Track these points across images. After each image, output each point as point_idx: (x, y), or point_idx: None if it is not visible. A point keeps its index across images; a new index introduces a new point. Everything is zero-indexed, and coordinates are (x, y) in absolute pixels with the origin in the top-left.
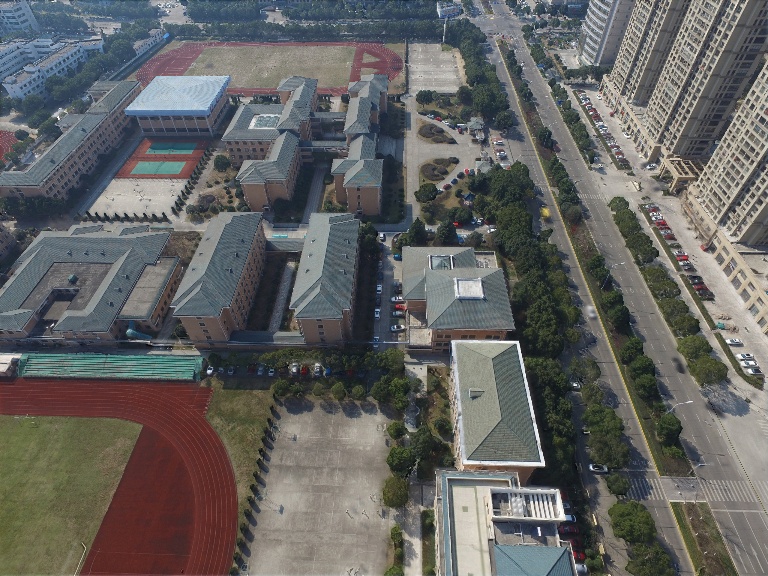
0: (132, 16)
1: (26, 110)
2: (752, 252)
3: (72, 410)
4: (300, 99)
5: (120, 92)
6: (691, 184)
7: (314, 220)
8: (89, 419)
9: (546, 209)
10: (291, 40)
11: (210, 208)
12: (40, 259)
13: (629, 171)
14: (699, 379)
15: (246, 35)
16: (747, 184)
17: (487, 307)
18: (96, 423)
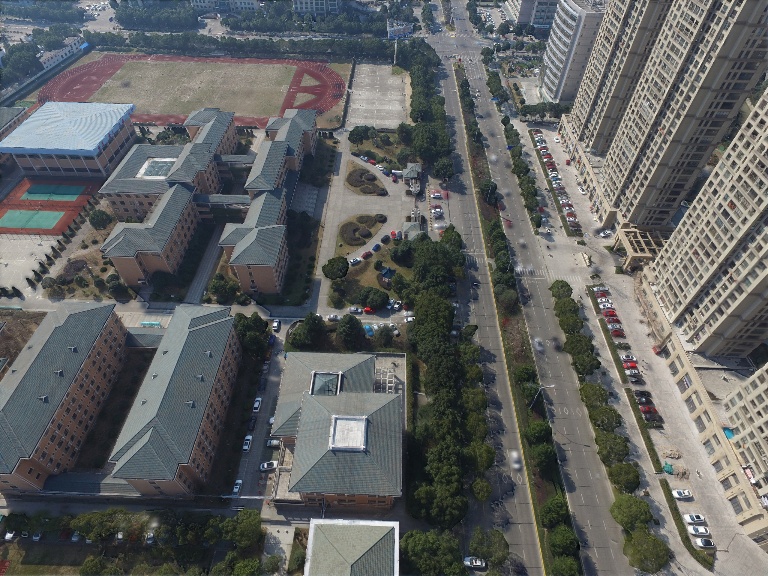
0: (54, 19)
1: None
2: (710, 367)
3: None
4: (205, 139)
5: None
6: (646, 266)
7: (175, 319)
8: None
9: (478, 289)
10: (226, 55)
11: (74, 280)
12: None
13: (580, 239)
14: (633, 563)
15: (176, 47)
16: (706, 286)
17: (367, 462)
18: None
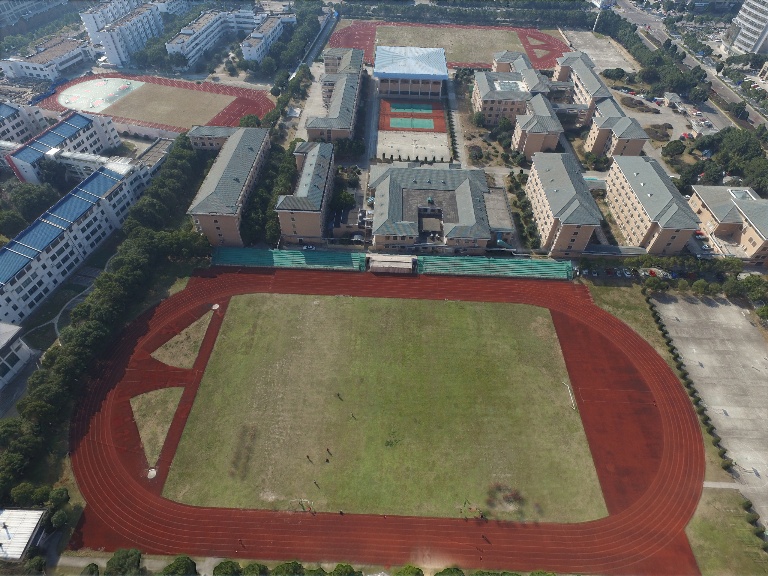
0: None
1: (264, 71)
2: None
3: (482, 297)
4: None
5: (357, 57)
6: None
7: (623, 160)
8: (501, 304)
9: None
10: (451, 23)
11: (487, 155)
12: (394, 185)
13: None
14: None
15: (408, 17)
16: None
17: None
18: (509, 306)
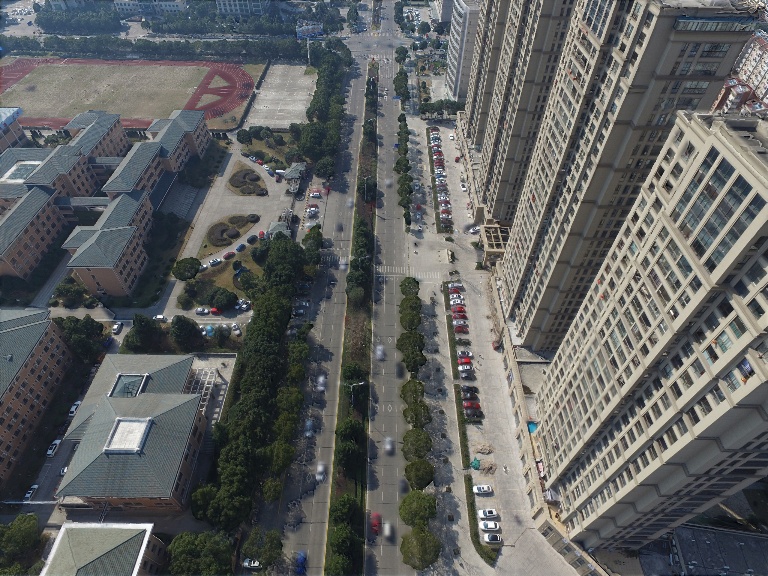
0: None
1: None
2: (533, 361)
3: None
4: (79, 142)
5: None
6: (497, 261)
7: None
8: None
9: (334, 287)
10: (141, 58)
11: None
12: None
13: (449, 235)
14: (405, 561)
15: (92, 51)
16: (525, 280)
17: (140, 464)
18: None
